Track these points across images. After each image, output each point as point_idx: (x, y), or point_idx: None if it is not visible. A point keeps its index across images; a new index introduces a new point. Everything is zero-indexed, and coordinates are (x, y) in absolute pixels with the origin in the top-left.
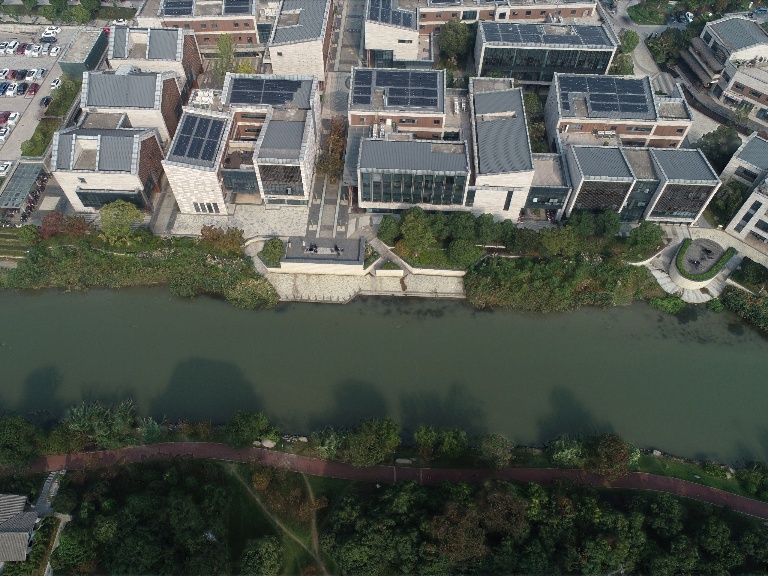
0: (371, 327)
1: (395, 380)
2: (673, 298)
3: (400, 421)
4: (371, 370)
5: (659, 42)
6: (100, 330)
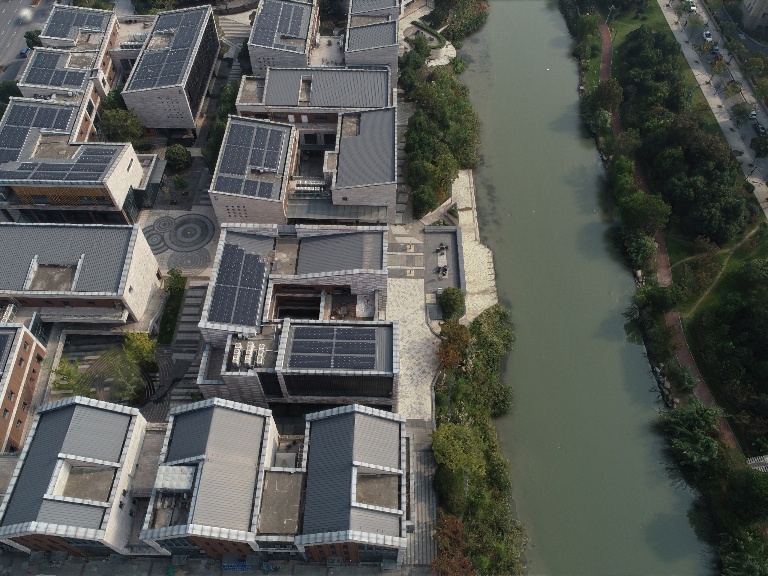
0: (514, 234)
1: (561, 219)
2: (455, 60)
3: (600, 214)
4: (558, 233)
5: (166, 2)
6: (575, 483)
